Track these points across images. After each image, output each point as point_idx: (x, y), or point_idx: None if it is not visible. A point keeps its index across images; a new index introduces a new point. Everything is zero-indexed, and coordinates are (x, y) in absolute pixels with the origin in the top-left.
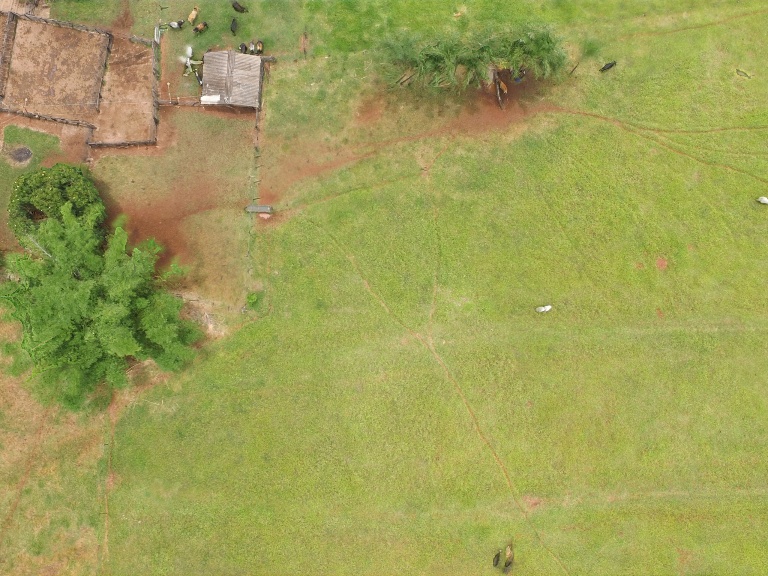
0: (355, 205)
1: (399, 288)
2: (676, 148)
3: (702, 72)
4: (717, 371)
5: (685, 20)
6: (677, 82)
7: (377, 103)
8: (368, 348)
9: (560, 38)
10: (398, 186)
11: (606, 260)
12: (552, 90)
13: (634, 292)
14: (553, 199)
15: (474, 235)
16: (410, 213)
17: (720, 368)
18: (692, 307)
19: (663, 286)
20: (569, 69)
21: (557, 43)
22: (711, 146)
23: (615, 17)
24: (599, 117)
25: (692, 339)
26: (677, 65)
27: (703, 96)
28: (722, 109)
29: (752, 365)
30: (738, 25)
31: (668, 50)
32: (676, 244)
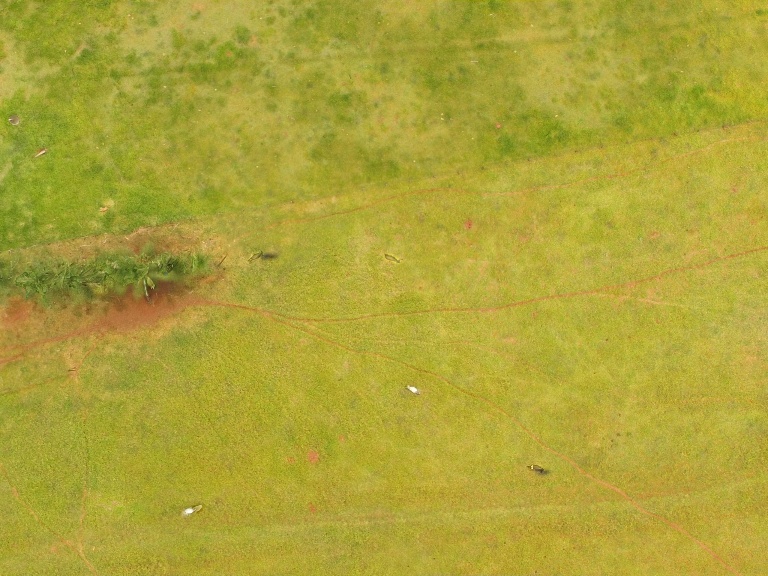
0: (1, 411)
1: (47, 495)
2: (325, 338)
3: (350, 258)
4: (369, 565)
5: (333, 205)
6: (324, 270)
7: (24, 303)
8: (16, 559)
9: (208, 229)
10: (45, 389)
11: (256, 456)
12: (201, 283)
13: (285, 487)
14: (201, 396)
15: (122, 437)
16: (57, 417)
17: (371, 562)
18: (345, 499)
19: (315, 479)
20: (218, 260)
21: (205, 234)
22: (360, 334)
23: (263, 205)
24: (248, 308)
25: (343, 533)
26: (324, 253)
27: (351, 283)
28: (371, 295)
29: (404, 557)
30: (385, 209)
31: (315, 237)
32: (326, 436)
